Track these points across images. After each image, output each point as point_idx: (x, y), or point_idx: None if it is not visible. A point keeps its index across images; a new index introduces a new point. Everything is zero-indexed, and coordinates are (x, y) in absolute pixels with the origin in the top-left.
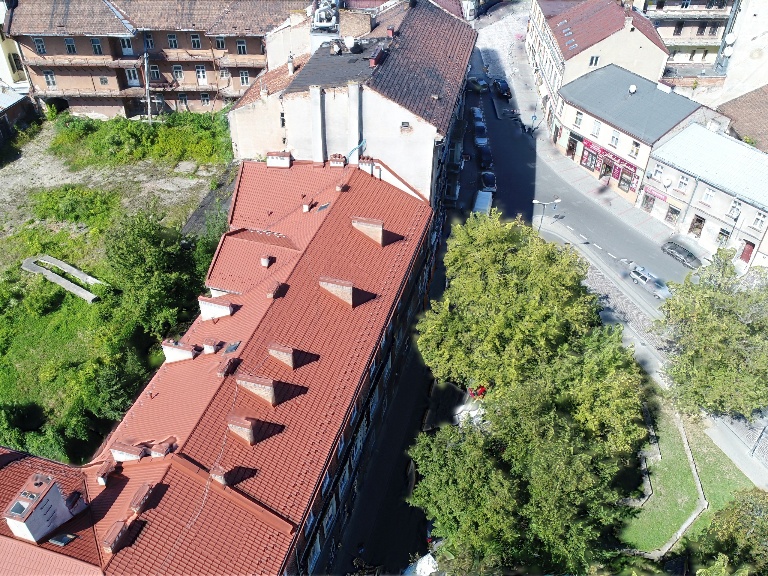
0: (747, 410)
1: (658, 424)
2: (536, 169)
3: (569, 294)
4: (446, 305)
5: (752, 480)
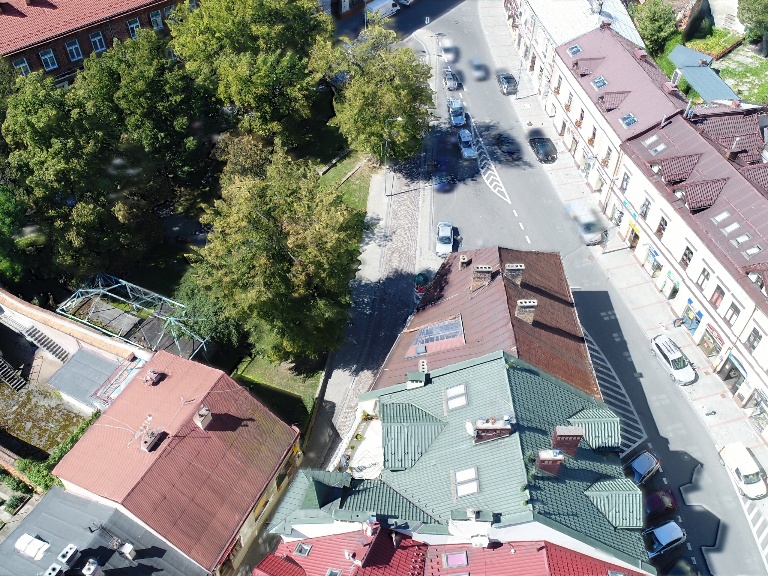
0: (344, 132)
1: (346, 160)
2: (465, 1)
3: (251, 12)
4: (186, 3)
5: (368, 206)
